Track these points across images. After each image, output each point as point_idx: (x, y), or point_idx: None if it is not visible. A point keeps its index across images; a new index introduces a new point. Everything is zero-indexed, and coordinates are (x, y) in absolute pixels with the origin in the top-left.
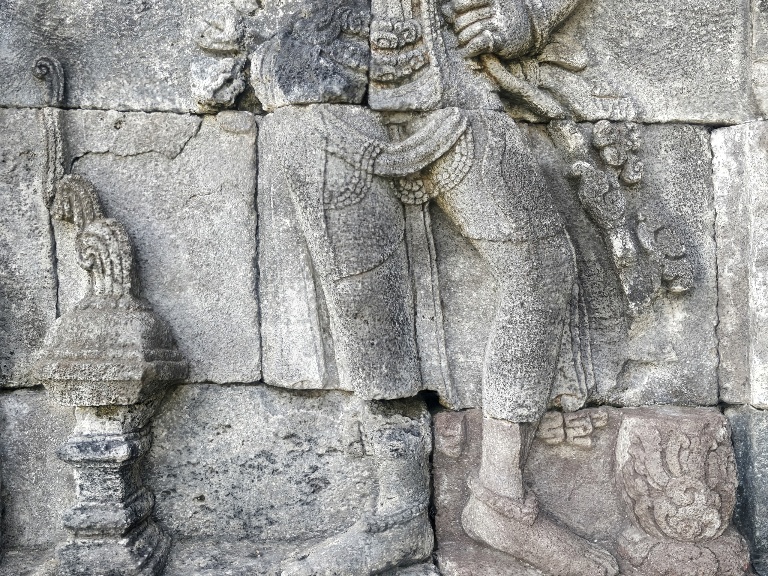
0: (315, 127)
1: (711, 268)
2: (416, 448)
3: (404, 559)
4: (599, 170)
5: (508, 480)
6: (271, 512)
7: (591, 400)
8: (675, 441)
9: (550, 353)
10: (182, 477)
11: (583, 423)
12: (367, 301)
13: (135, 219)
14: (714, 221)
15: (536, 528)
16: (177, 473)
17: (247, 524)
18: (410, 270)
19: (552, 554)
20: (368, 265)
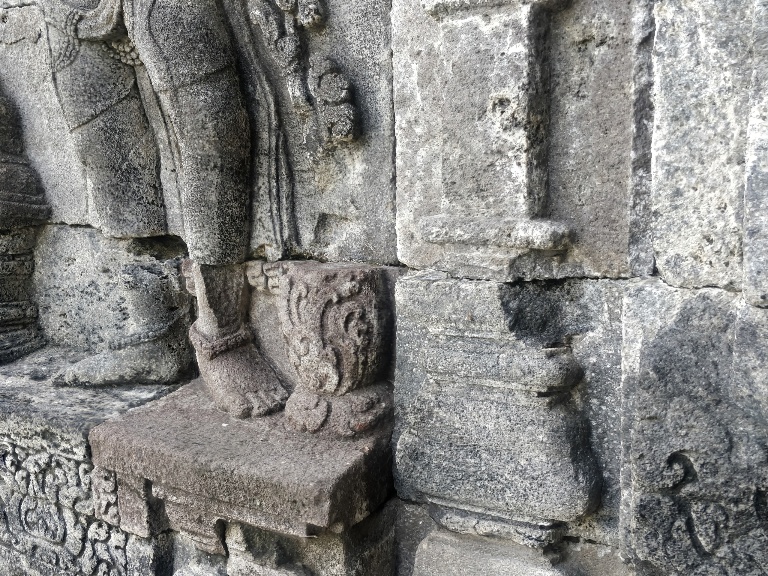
0: (37, 2)
1: (387, 115)
2: (151, 283)
3: (138, 377)
4: (271, 17)
5: (204, 318)
6: (100, 332)
7: (297, 253)
8: (296, 290)
9: (208, 198)
10: (52, 297)
11: (276, 273)
12: (87, 150)
13: (19, 94)
14: (391, 62)
15: (214, 363)
16: (50, 294)
17: (88, 340)
18: (150, 126)
19: (217, 387)
20: (82, 119)
